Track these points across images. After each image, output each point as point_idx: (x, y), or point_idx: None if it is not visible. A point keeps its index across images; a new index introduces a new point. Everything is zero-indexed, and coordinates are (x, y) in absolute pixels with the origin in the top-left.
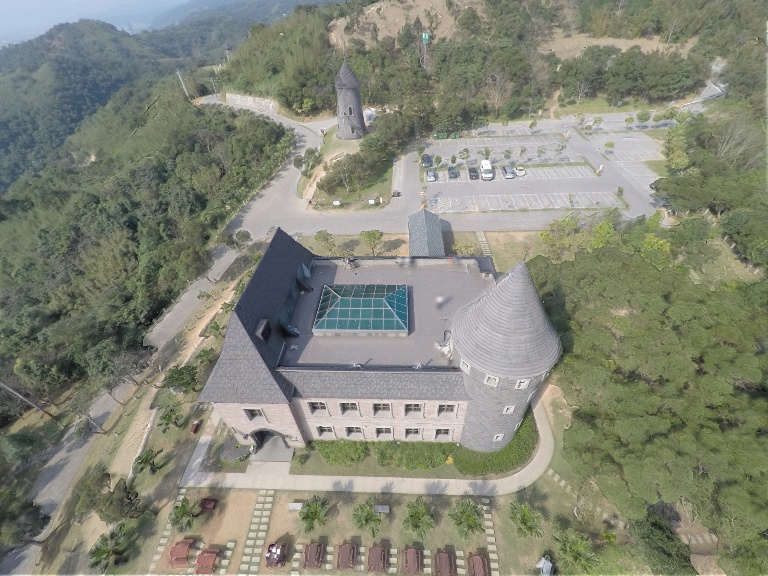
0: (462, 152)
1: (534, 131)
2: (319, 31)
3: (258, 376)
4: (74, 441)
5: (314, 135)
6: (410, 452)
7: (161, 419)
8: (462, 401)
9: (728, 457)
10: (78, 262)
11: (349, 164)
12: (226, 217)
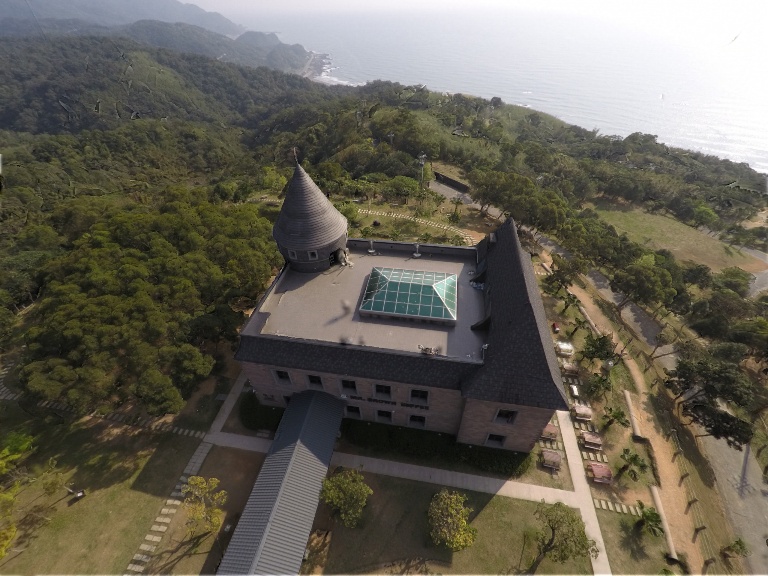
0: None
1: None
2: None
3: None
4: None
5: None
6: None
7: None
8: None
9: (231, 225)
10: None
11: None
12: None
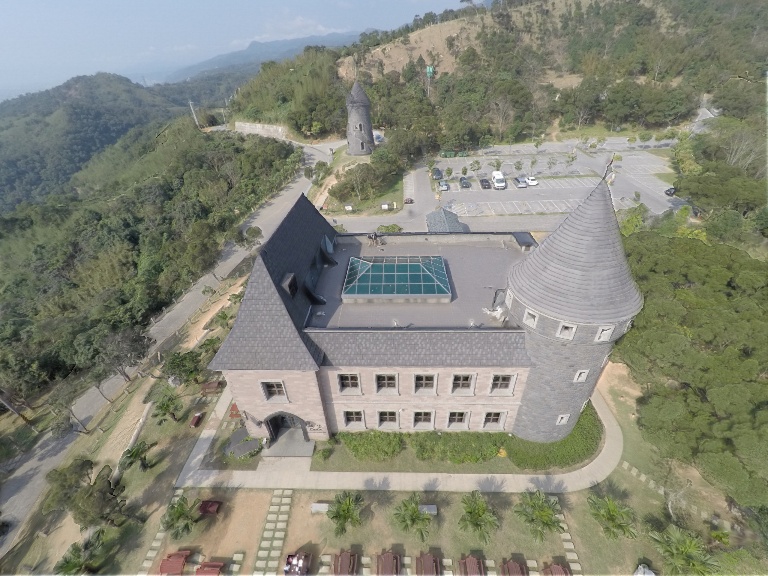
0: (473, 164)
1: (539, 151)
2: (328, 65)
3: (282, 336)
4: (49, 448)
5: (323, 154)
6: (454, 444)
7: (157, 409)
8: (522, 369)
9: None
10: (73, 274)
11: (362, 171)
12: (234, 221)
